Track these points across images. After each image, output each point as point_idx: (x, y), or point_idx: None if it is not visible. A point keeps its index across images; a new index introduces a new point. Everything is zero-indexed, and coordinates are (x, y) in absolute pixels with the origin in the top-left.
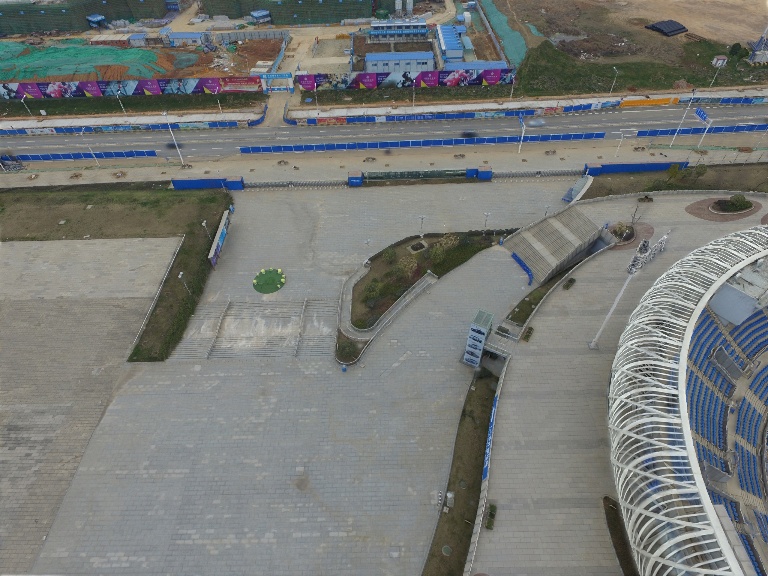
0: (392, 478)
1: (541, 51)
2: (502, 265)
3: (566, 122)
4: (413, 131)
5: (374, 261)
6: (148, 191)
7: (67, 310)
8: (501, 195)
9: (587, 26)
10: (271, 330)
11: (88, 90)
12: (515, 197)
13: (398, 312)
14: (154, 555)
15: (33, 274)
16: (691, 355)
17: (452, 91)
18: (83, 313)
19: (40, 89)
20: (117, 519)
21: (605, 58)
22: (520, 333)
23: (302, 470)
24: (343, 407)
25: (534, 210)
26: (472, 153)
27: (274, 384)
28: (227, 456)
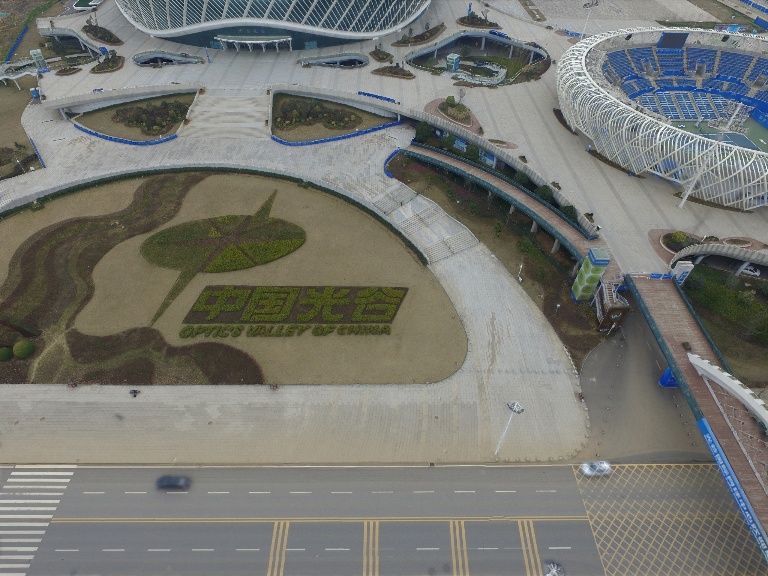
0: None
1: None
2: None
3: None
4: None
5: None
6: None
7: (665, 10)
8: None
9: None
10: None
11: None
12: None
13: None
14: None
15: (674, 4)
16: (758, 64)
17: None
18: (666, 12)
19: None
20: None
21: None
22: None
23: None
24: None
25: None
26: None
27: None
28: None
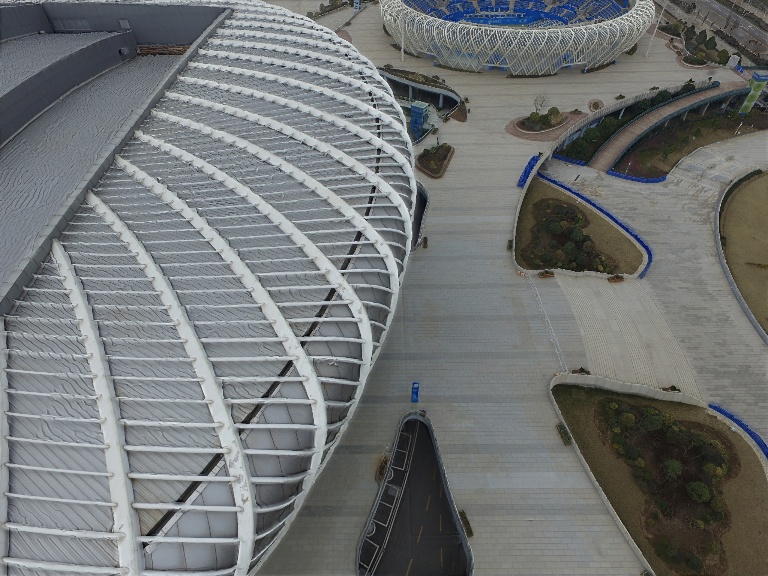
0: None
1: None
2: None
3: None
4: None
5: (326, 8)
6: None
7: None
8: None
9: None
10: None
11: None
12: None
13: (332, 13)
14: None
15: None
16: None
17: None
18: None
19: None
20: None
21: None
22: (373, 2)
23: None
24: None
25: None
26: None
27: None
28: None
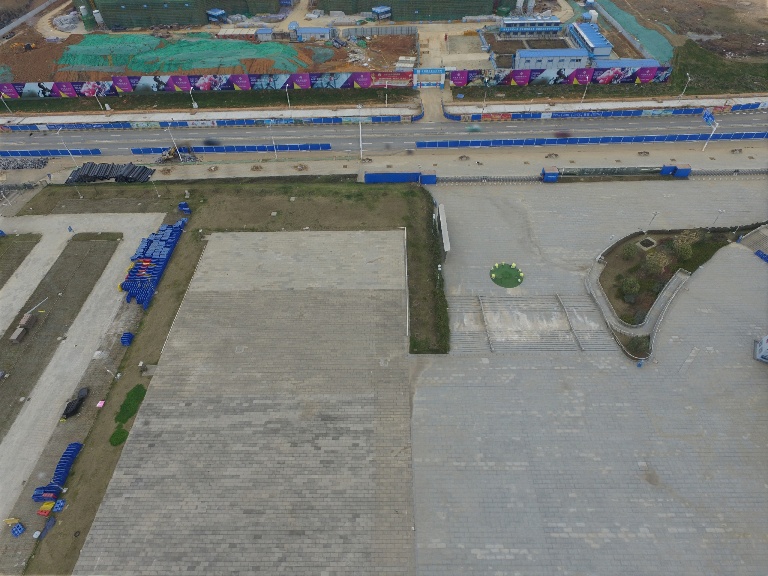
0: (743, 475)
1: (688, 50)
2: (749, 263)
3: (737, 121)
4: (584, 128)
5: (607, 257)
6: (340, 184)
7: (323, 301)
8: (705, 193)
9: (718, 25)
10: (537, 324)
11: (238, 83)
12: (721, 195)
13: None
14: (535, 548)
15: (271, 265)
16: None
17: (606, 89)
18: (341, 304)
19: (190, 82)
20: (478, 511)
21: (752, 57)
22: None
23: (645, 465)
24: (656, 402)
25: (747, 208)
26: (654, 151)
27: (573, 378)
28: (560, 450)
